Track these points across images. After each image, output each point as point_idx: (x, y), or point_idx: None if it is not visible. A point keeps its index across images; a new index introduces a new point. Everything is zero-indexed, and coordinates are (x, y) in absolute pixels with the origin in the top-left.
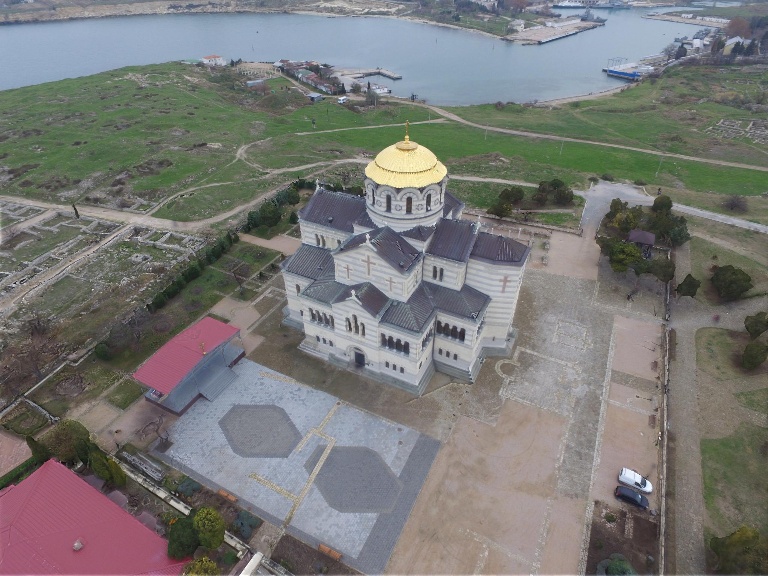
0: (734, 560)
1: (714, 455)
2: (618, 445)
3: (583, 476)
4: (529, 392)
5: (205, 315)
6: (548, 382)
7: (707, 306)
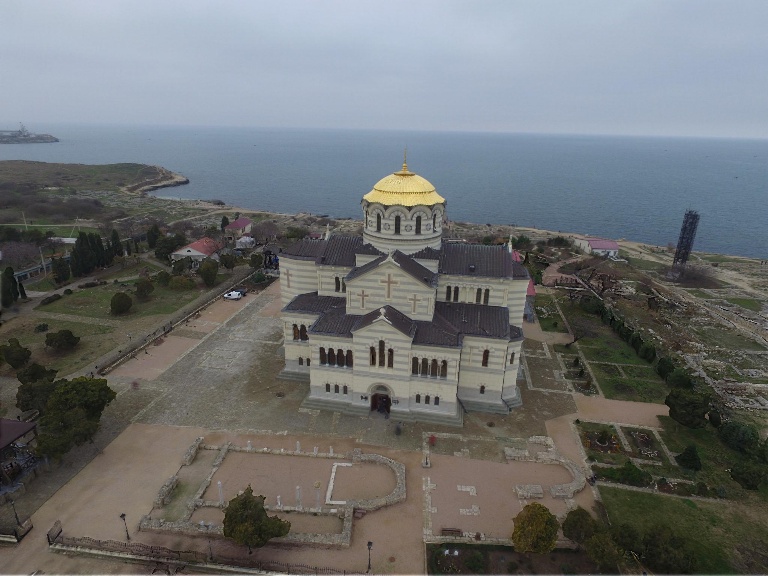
0: (217, 263)
1: (171, 309)
2: (230, 308)
3: (260, 299)
4: (279, 322)
5: (569, 331)
6: (262, 328)
7: (7, 403)
